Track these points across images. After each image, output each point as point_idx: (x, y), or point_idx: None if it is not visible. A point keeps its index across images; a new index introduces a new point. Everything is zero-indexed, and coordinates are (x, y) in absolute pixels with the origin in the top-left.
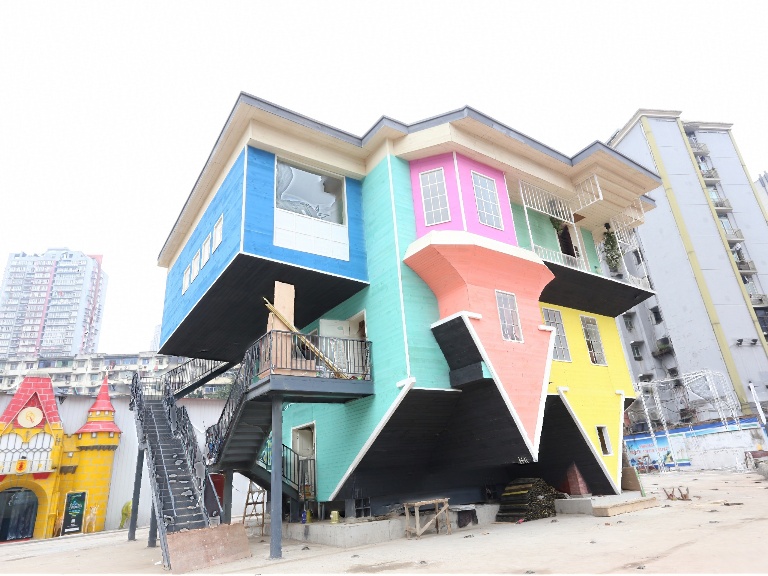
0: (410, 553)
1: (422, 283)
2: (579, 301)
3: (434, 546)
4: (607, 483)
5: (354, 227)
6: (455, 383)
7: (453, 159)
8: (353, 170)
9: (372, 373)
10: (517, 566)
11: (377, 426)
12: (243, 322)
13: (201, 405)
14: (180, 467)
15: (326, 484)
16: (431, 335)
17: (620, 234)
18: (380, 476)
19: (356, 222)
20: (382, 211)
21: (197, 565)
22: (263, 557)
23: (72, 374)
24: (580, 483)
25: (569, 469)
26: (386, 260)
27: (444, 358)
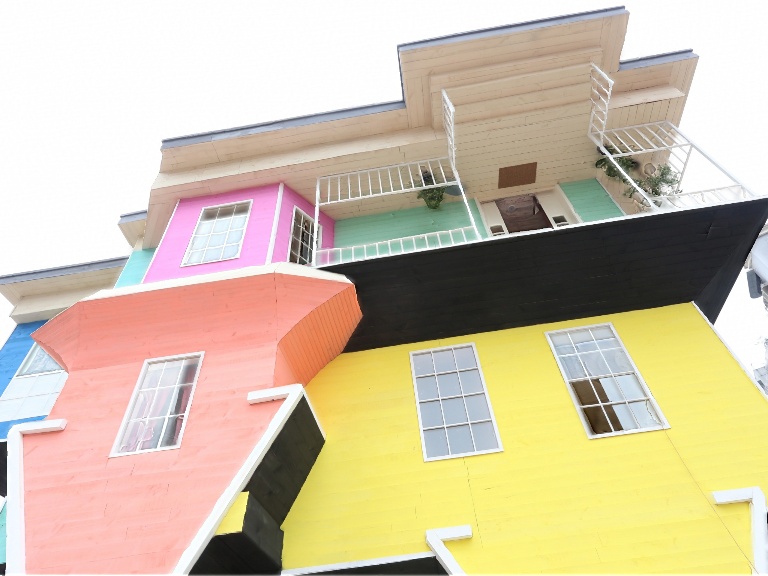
0: None
1: None
2: (522, 305)
3: None
4: None
5: None
6: None
7: None
8: None
9: None
10: None
11: None
12: None
13: None
14: None
15: None
16: None
17: (620, 145)
18: None
19: None
20: None
21: None
22: None
23: None
24: None
25: None
26: None
27: None
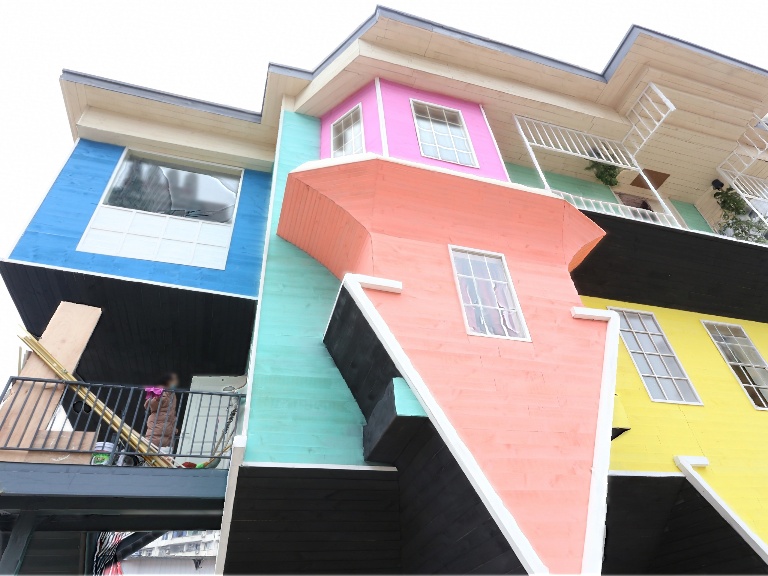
0: None
1: (316, 266)
2: (690, 293)
3: None
4: None
5: (246, 226)
6: (367, 448)
7: (374, 86)
8: (252, 156)
9: None
10: None
11: None
12: None
13: None
14: None
15: None
16: (322, 353)
17: (744, 187)
18: None
19: (252, 220)
20: None
21: None
22: None
23: (201, 542)
24: None
25: None
26: None
27: (351, 397)
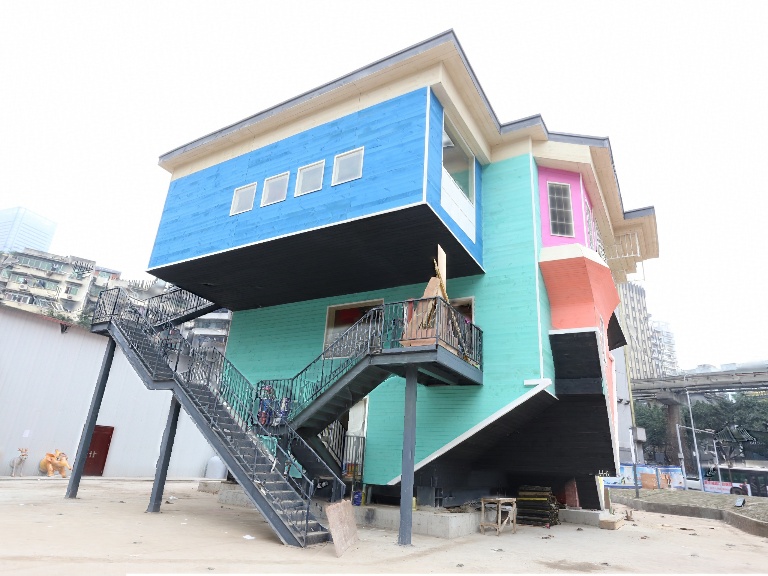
0: (548, 552)
1: (545, 288)
2: None
3: (545, 546)
4: (597, 500)
5: (478, 211)
6: (562, 391)
7: (580, 180)
8: (486, 153)
9: (482, 363)
10: (713, 575)
11: (488, 418)
12: (306, 269)
13: (98, 339)
14: (226, 421)
15: (383, 466)
16: (549, 341)
17: None
18: (449, 467)
19: (478, 206)
20: (515, 205)
21: (343, 546)
22: (380, 541)
23: None
24: (577, 497)
25: (568, 483)
26: (516, 255)
27: (553, 365)
